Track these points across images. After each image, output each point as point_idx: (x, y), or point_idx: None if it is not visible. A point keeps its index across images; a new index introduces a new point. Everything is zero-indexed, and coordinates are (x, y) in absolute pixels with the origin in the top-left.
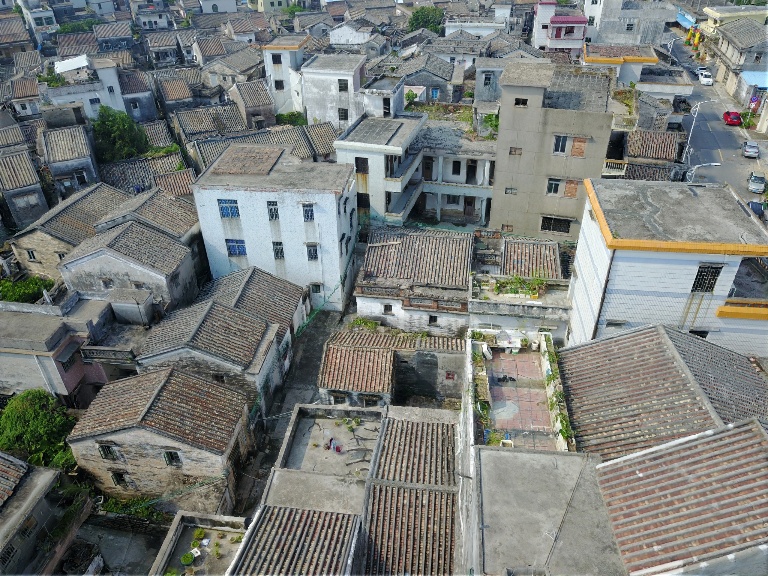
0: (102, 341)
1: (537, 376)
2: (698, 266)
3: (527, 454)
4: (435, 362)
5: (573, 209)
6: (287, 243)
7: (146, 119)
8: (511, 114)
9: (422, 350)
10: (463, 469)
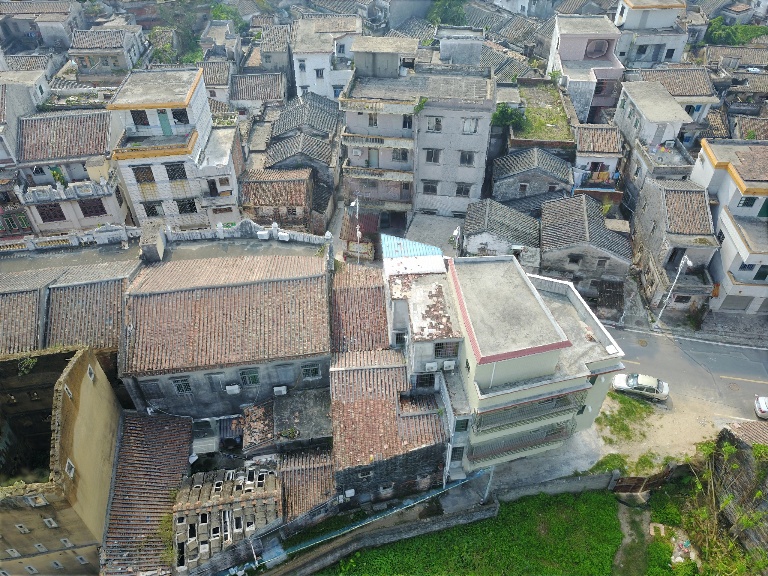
0: (218, 54)
1: None
2: None
3: None
4: None
5: None
6: None
7: (536, 16)
8: None
9: None
10: None
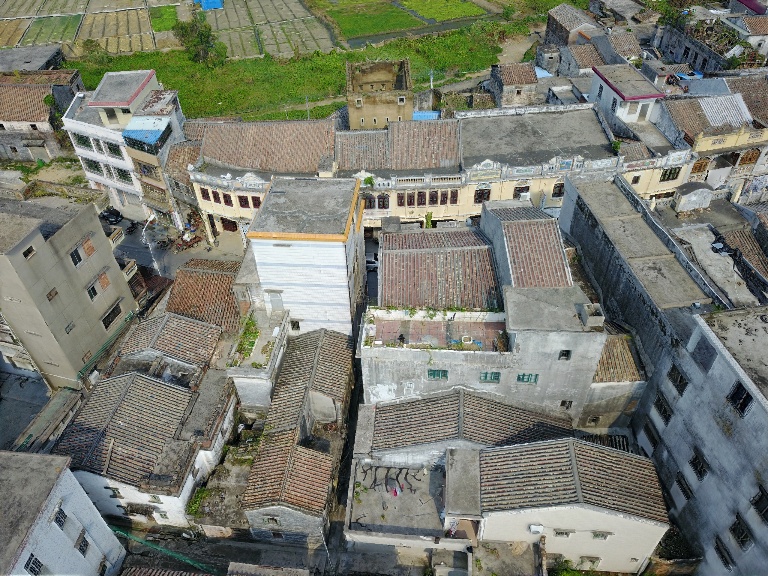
0: None
1: (398, 323)
2: None
3: (509, 311)
4: (304, 419)
5: (114, 293)
6: (63, 573)
7: None
8: (28, 269)
9: None
10: (445, 387)
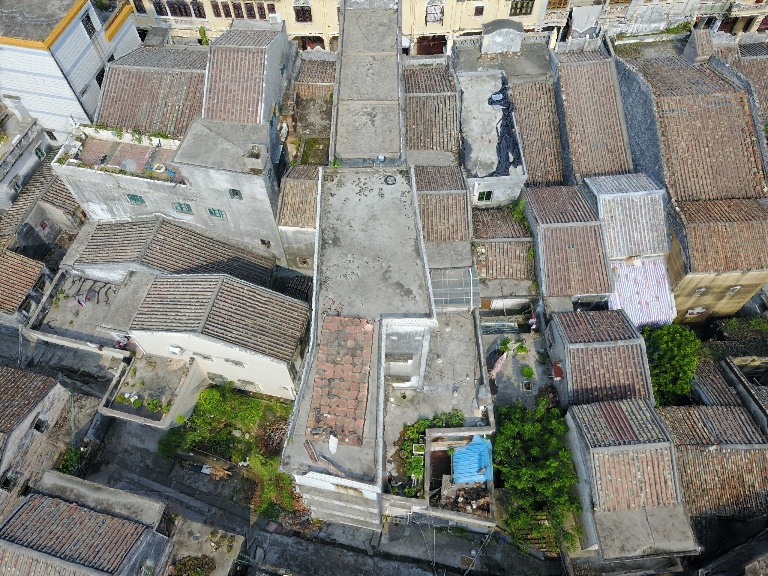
0: None
1: (108, 144)
2: (81, 22)
3: (183, 143)
4: (30, 227)
5: None
6: None
7: None
8: None
9: (18, 229)
10: (148, 213)
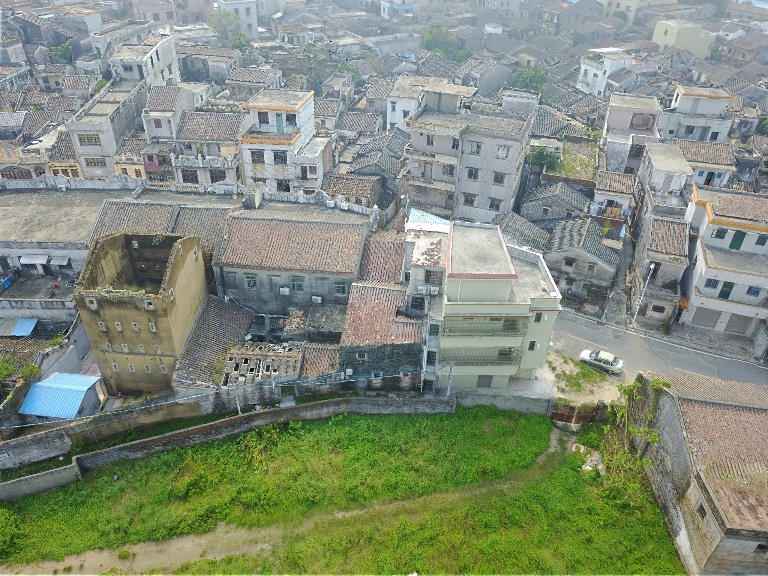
0: None
1: None
2: None
3: None
4: None
5: None
6: None
7: None
8: None
9: None
10: None
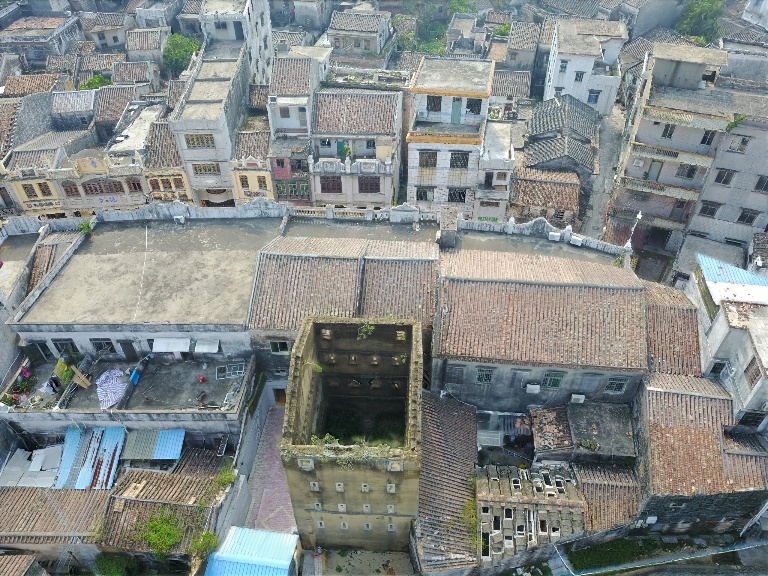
0: (463, 47)
1: None
2: None
3: None
4: None
5: None
6: None
7: None
8: None
9: None
10: None
